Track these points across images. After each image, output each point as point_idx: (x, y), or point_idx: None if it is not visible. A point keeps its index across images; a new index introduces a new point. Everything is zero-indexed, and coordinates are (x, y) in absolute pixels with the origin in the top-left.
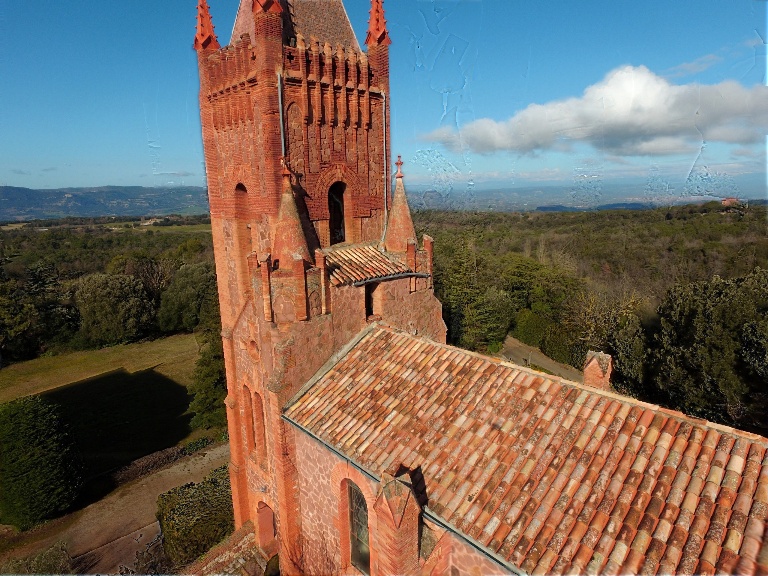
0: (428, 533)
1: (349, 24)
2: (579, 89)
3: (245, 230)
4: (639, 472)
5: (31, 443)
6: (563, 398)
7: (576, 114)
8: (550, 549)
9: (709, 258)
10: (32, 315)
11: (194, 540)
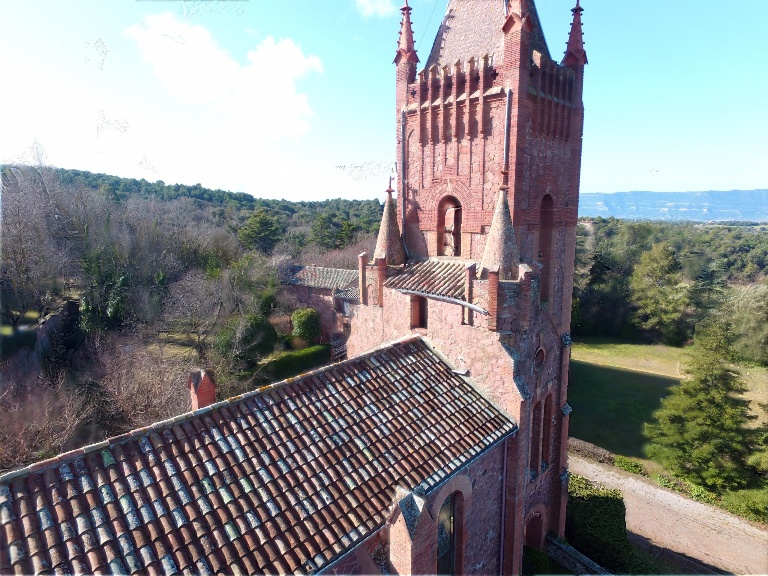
0: None
1: None
2: None
3: None
4: None
5: None
6: None
7: None
8: None
9: None
10: (690, 309)
11: None
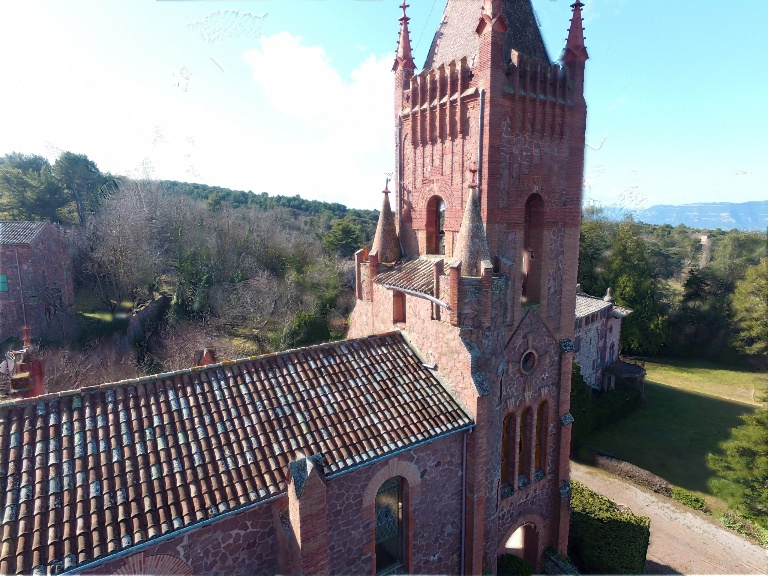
0: None
1: None
2: None
3: None
4: None
5: None
6: None
7: None
8: None
9: None
10: None
11: None
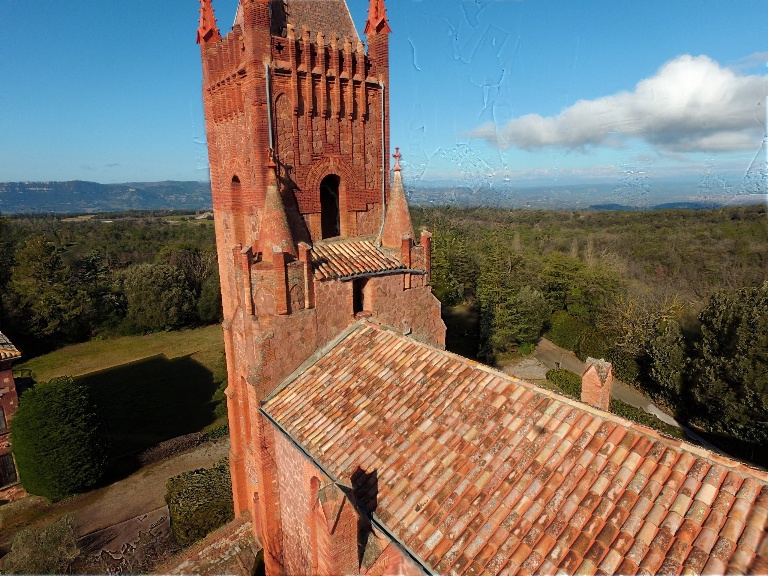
0: (373, 541)
1: None
2: (627, 80)
3: (242, 222)
4: (597, 494)
5: (61, 421)
6: (533, 407)
7: (623, 107)
8: (487, 571)
9: (766, 262)
10: (85, 301)
11: (195, 525)
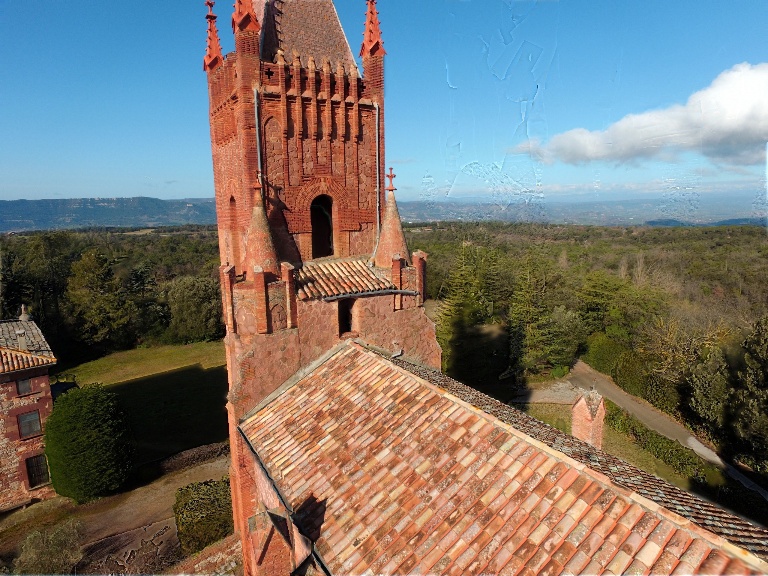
0: (312, 574)
1: (344, 37)
2: (672, 92)
3: None
4: (534, 543)
5: (89, 426)
6: (490, 442)
7: (668, 120)
8: None
9: None
10: (132, 310)
11: (196, 536)
